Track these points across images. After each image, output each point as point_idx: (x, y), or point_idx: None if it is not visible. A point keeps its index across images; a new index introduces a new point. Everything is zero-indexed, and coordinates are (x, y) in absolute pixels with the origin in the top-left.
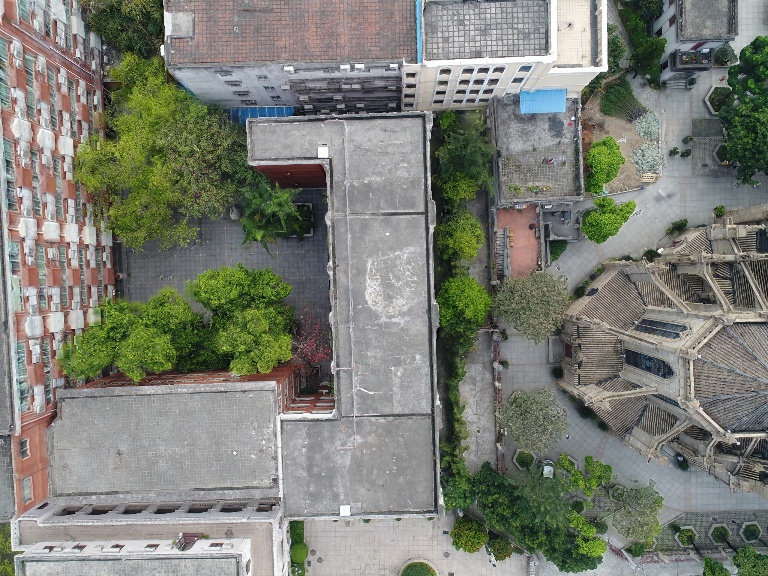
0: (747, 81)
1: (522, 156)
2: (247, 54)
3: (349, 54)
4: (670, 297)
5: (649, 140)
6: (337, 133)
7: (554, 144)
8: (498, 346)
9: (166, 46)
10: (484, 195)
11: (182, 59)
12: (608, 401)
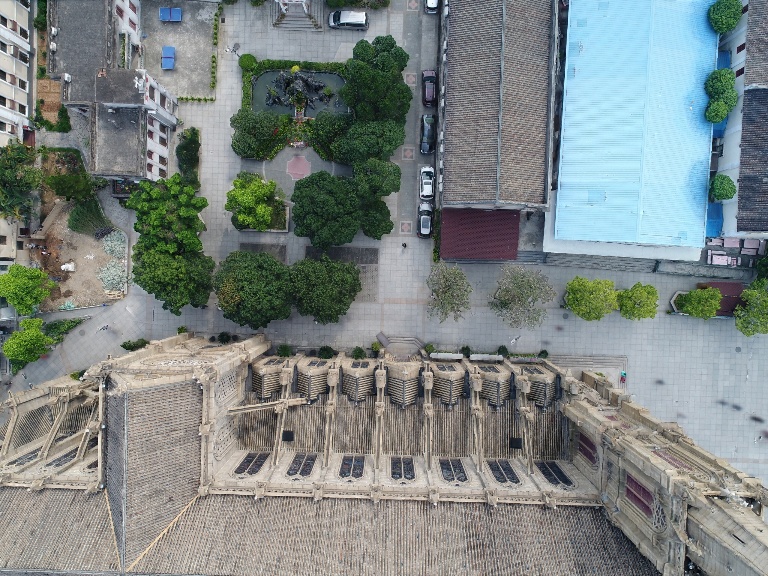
0: None
1: None
2: None
3: None
4: (5, 437)
5: (117, 258)
6: None
7: None
8: None
9: None
10: None
11: None
12: None
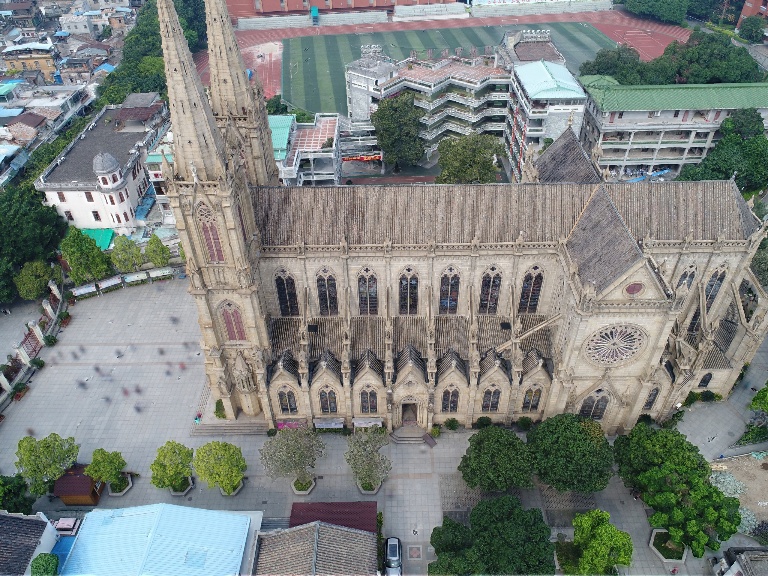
0: None
1: None
2: None
3: None
4: None
5: None
6: None
7: None
8: None
9: None
10: None
11: None
12: None
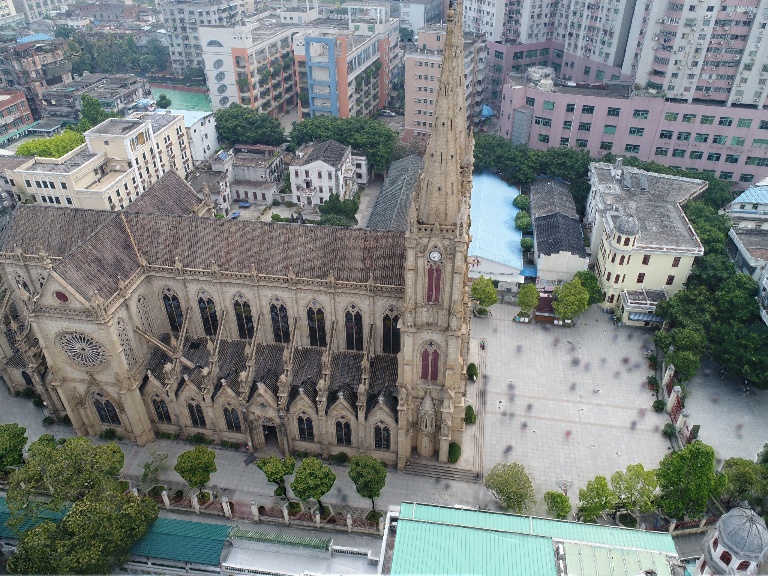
0: None
1: None
2: None
3: None
4: None
5: None
6: None
7: None
8: None
9: None
10: None
11: None
12: (8, 340)
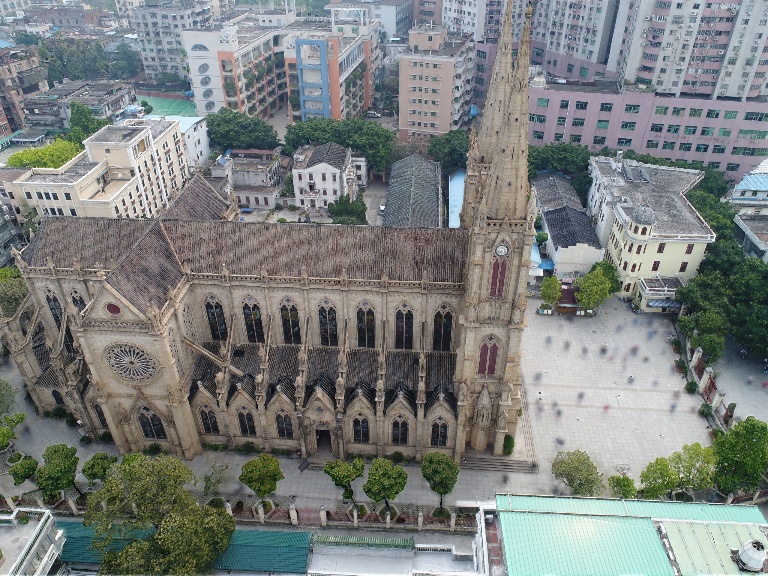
0: None
1: None
2: None
3: None
4: None
5: None
6: None
7: None
8: (1, 360)
9: None
10: None
11: None
12: None
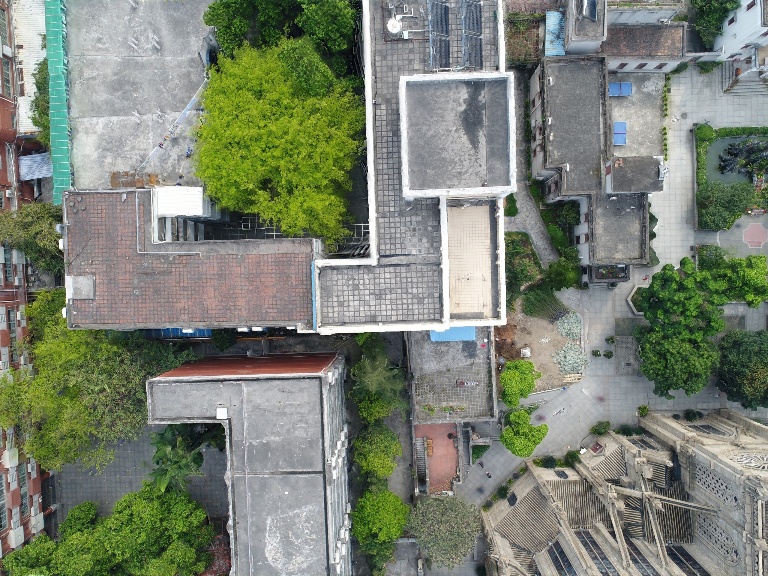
0: (656, 311)
1: (436, 376)
2: (147, 316)
3: (247, 316)
4: (572, 545)
5: (572, 340)
6: (236, 393)
7: (468, 364)
8: None
9: (68, 309)
10: (407, 394)
11: (84, 320)
12: None
